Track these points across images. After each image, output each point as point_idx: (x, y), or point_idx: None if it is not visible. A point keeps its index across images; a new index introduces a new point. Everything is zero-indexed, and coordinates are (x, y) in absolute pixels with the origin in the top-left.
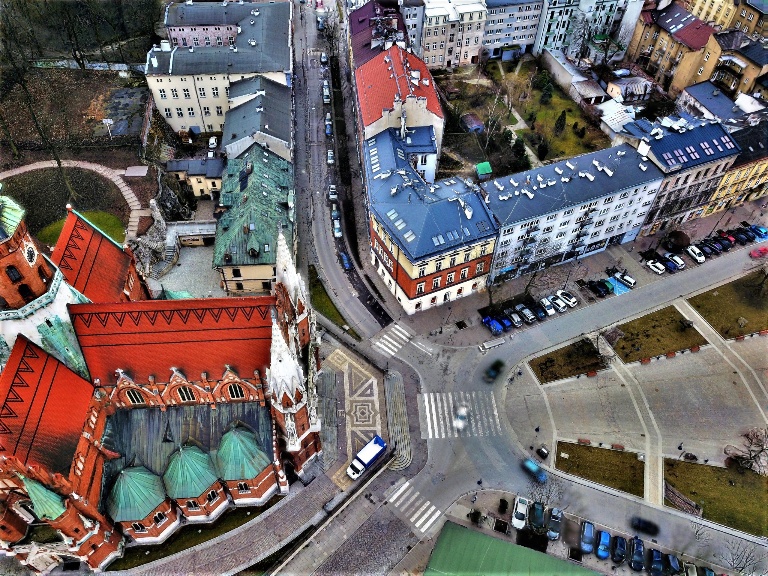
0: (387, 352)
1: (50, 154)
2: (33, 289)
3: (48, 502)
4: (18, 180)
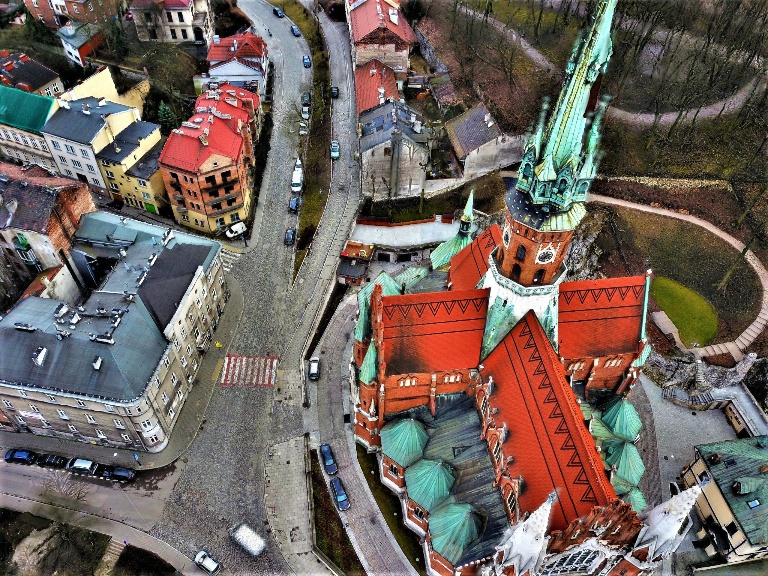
0: None
1: (759, 247)
2: (521, 275)
3: (368, 368)
4: (708, 237)
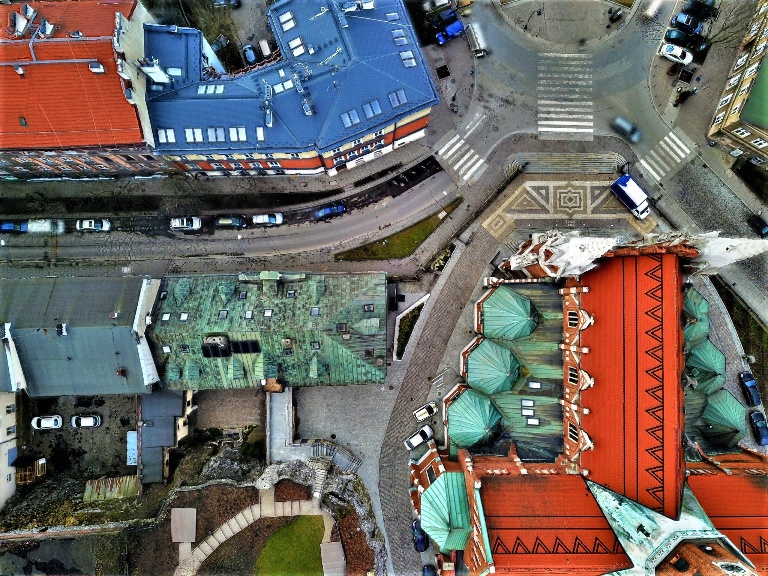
0: (479, 168)
1: None
2: None
3: None
4: None
